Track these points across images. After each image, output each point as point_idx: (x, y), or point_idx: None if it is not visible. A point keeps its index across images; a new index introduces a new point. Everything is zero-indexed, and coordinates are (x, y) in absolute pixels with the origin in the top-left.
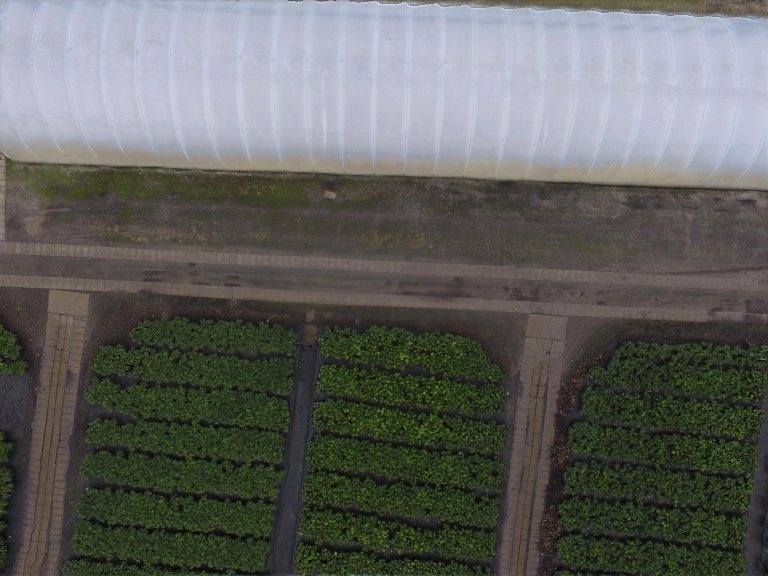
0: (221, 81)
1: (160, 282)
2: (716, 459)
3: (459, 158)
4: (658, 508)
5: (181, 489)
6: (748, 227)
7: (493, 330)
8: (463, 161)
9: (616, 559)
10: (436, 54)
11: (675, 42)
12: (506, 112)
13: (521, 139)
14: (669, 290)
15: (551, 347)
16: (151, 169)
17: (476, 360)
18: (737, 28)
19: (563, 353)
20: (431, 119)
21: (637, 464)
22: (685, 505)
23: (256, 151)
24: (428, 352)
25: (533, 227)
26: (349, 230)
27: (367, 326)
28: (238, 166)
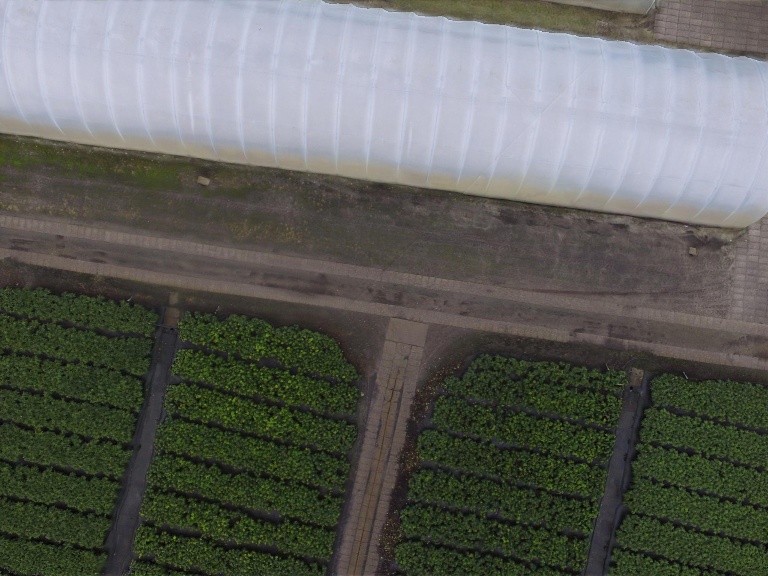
0: (87, 56)
1: (27, 251)
2: (563, 480)
3: (328, 155)
4: (501, 523)
5: (27, 459)
6: (618, 251)
7: (353, 330)
8: (332, 159)
9: (453, 570)
10: (304, 49)
11: (545, 59)
12: (370, 113)
13: (387, 142)
14: (533, 307)
15: (410, 352)
16: (28, 138)
17: (331, 358)
18: (613, 51)
19: (421, 360)
20: (296, 113)
21: (484, 477)
22: (527, 522)
23: (126, 129)
24: (285, 346)
25: (403, 231)
26: (219, 217)
27: (229, 314)
28: (114, 143)
